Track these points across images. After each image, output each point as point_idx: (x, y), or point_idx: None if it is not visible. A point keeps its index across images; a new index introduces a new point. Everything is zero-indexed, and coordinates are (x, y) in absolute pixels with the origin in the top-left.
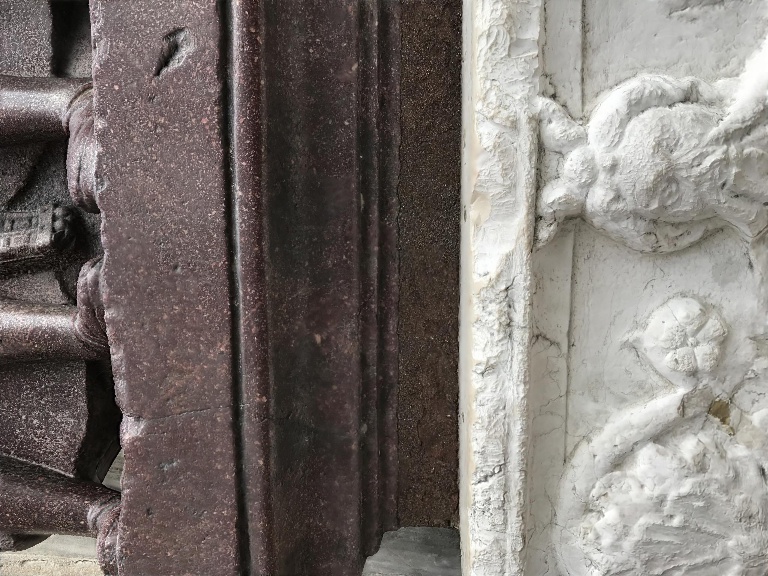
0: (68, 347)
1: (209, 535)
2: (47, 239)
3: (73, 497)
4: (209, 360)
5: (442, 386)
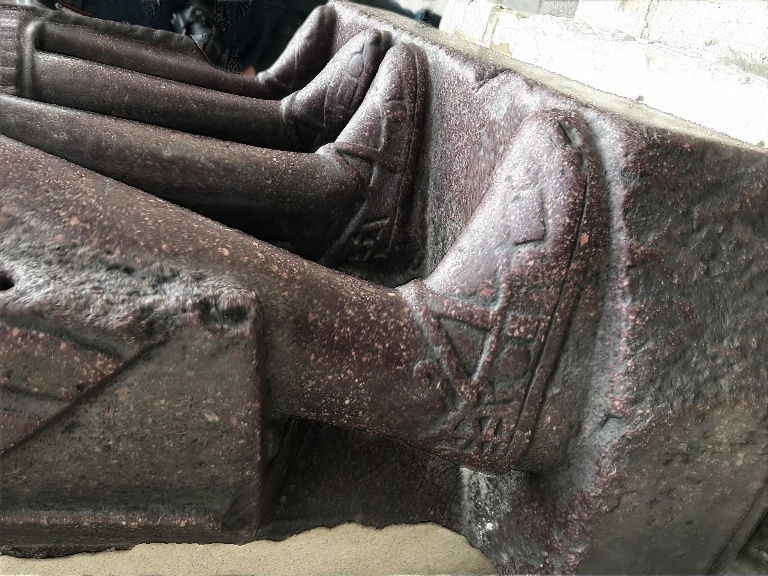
0: (317, 168)
1: None
2: None
3: None
4: None
5: None
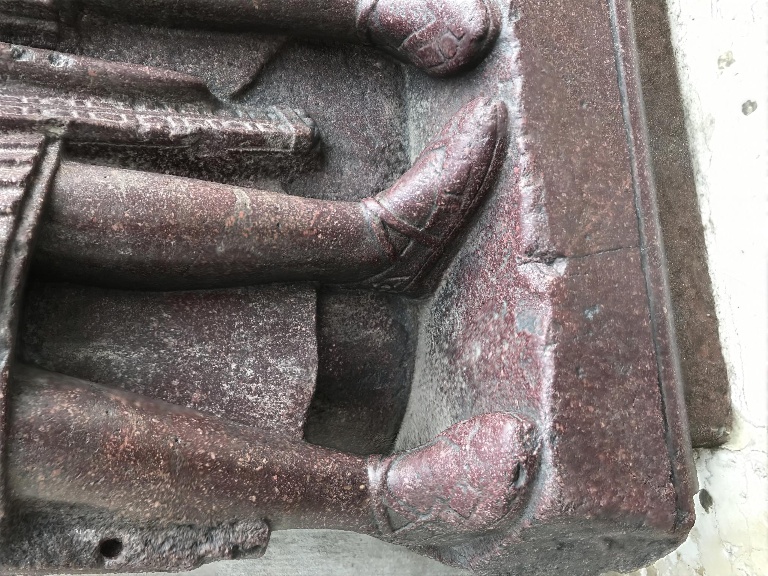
0: (357, 240)
1: (636, 396)
2: (307, 129)
3: (341, 455)
4: (618, 197)
5: (699, 287)
